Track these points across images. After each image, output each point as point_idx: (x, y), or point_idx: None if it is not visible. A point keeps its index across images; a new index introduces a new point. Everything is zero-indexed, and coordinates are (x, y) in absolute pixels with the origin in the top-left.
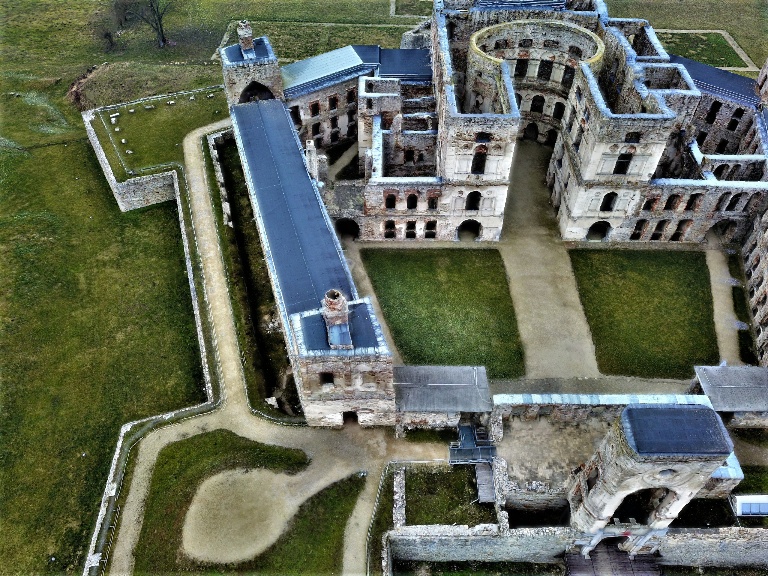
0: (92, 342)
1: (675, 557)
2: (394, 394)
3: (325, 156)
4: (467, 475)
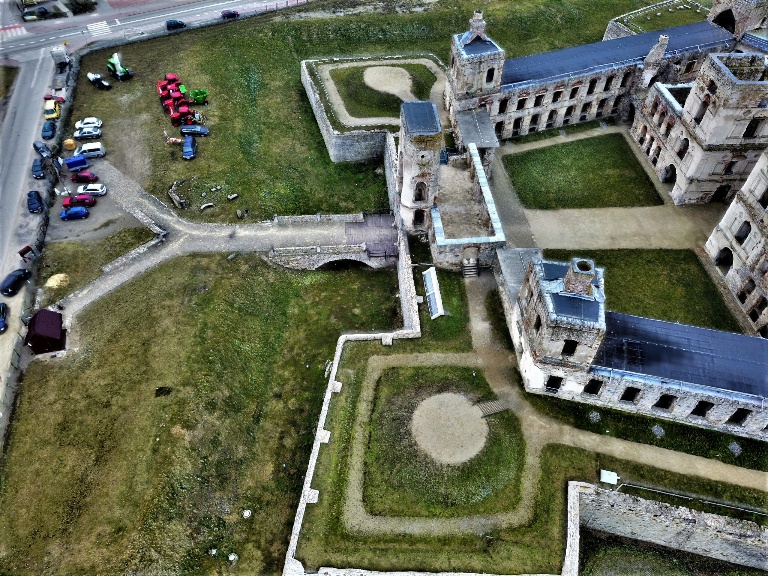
0: None
1: None
2: (457, 96)
3: (680, 67)
4: None
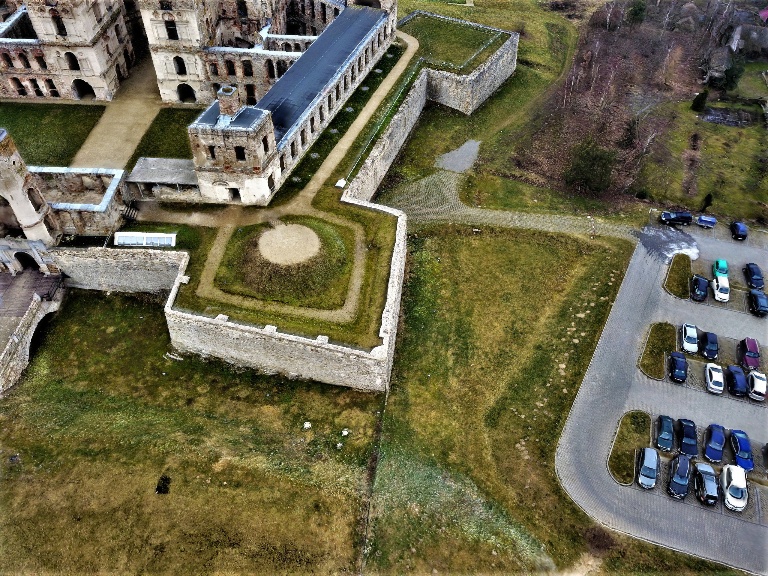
0: None
1: (82, 279)
2: None
3: None
4: None
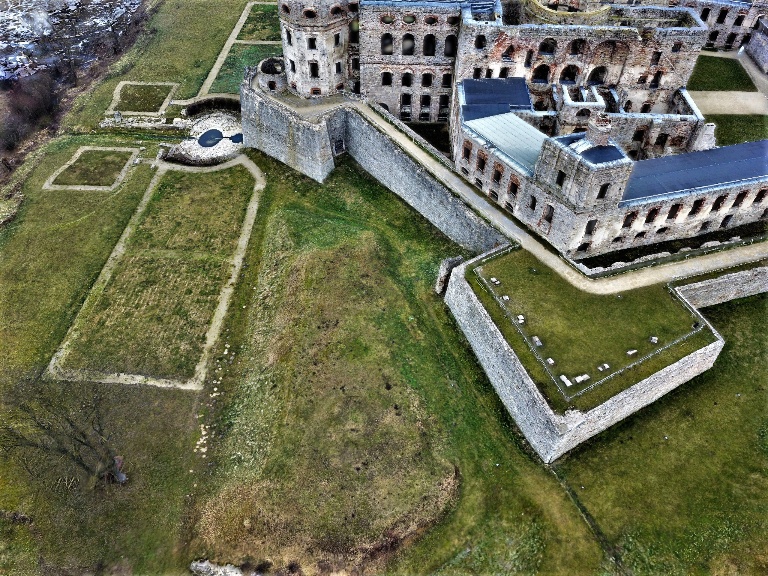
0: None
1: None
2: None
3: (668, 147)
4: None
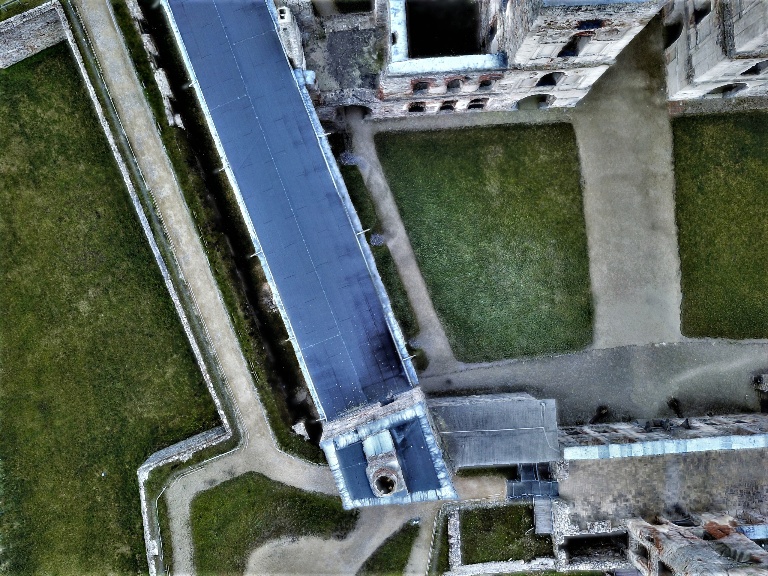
0: (52, 319)
1: None
2: None
3: None
4: (524, 505)
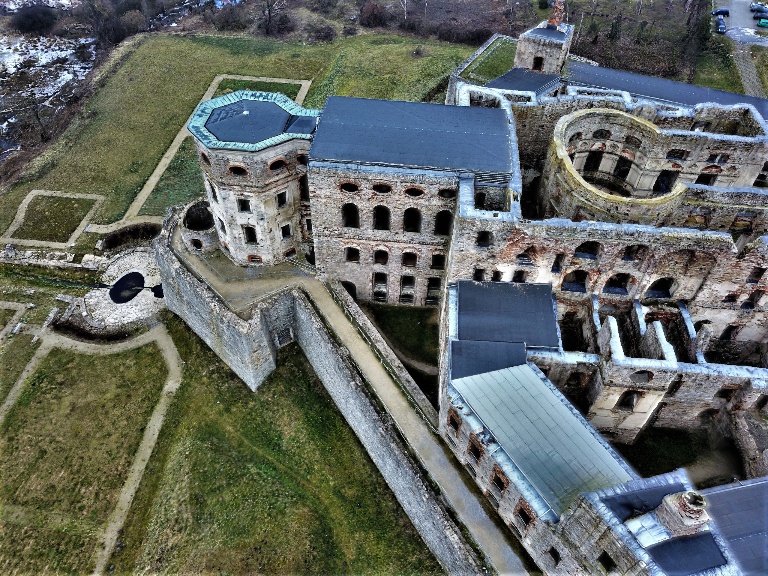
0: None
1: None
2: None
3: None
4: None
